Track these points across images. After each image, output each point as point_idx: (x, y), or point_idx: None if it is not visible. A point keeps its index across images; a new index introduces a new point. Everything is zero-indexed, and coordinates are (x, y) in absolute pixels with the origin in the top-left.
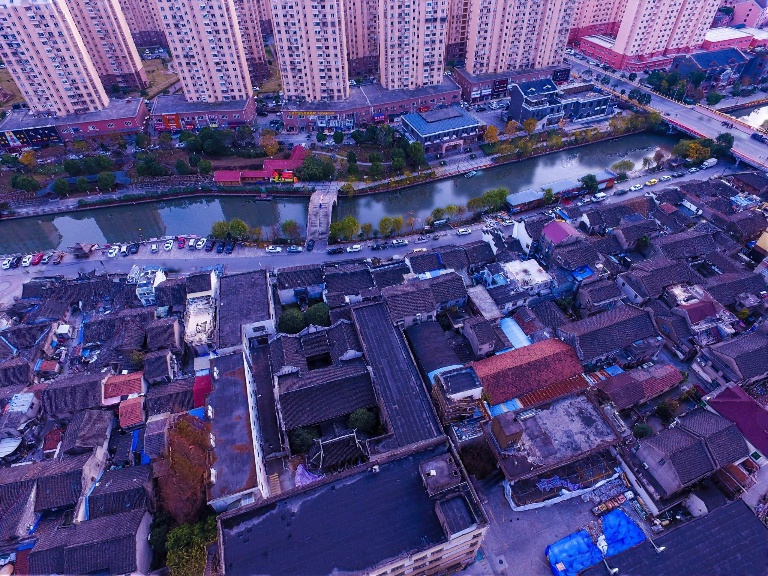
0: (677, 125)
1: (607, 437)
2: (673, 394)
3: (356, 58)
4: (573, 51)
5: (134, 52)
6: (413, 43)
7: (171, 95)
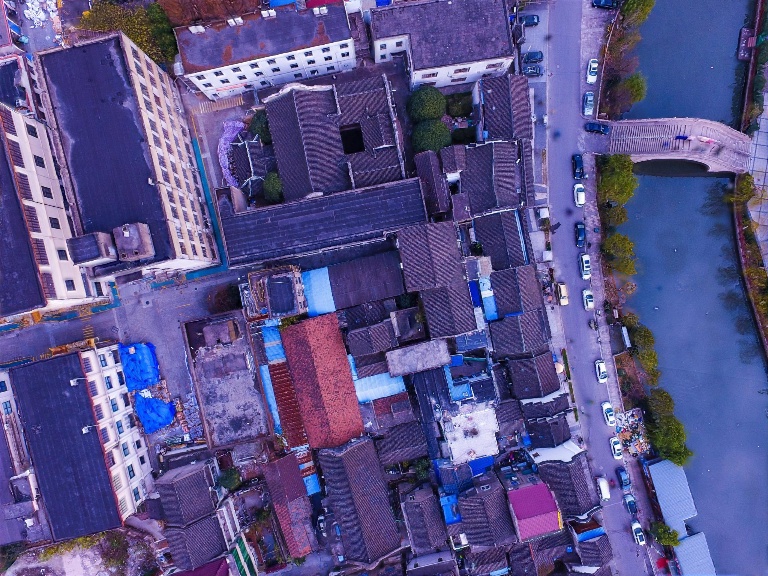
0: None
1: (217, 436)
2: None
3: None
4: None
5: None
6: None
7: None
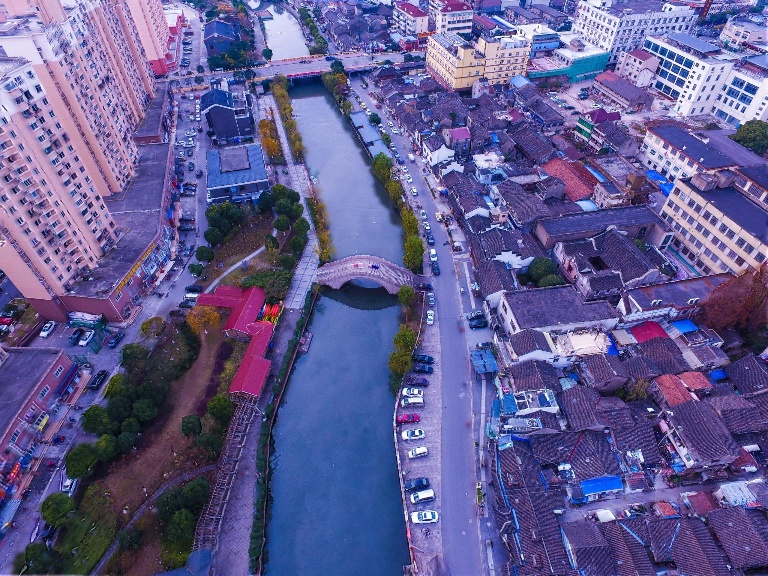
0: (296, 76)
1: None
2: None
3: None
4: None
5: None
6: (108, 120)
7: None
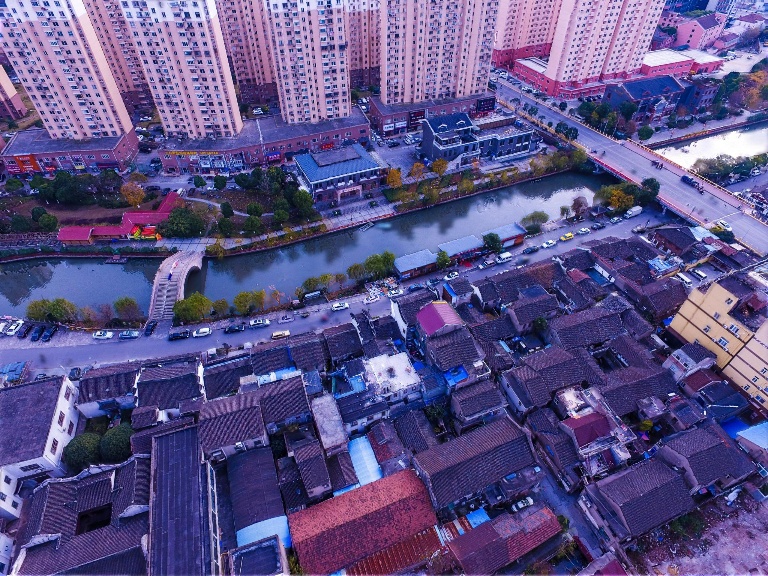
0: (603, 165)
1: None
2: (551, 546)
3: (264, 84)
4: (507, 74)
5: (2, 78)
6: (309, 73)
7: (35, 130)
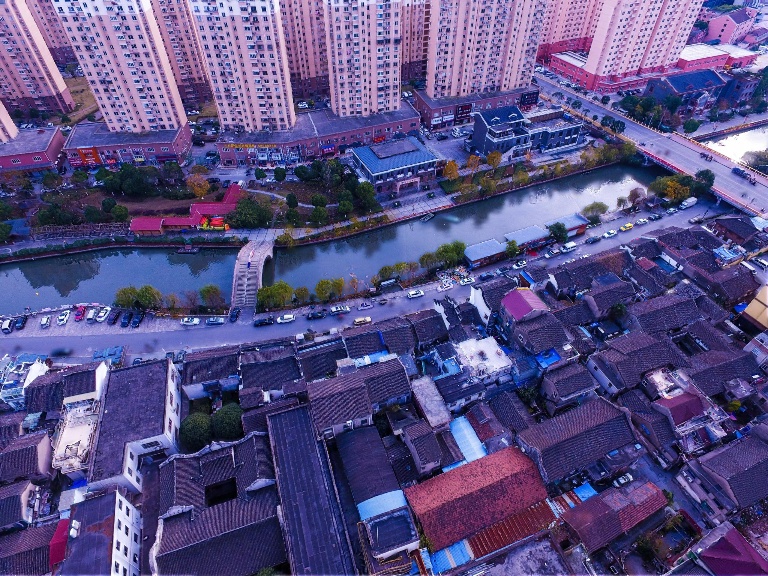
0: (653, 157)
1: None
2: (655, 519)
3: (308, 78)
4: (543, 69)
5: (54, 72)
6: (364, 67)
7: (92, 123)
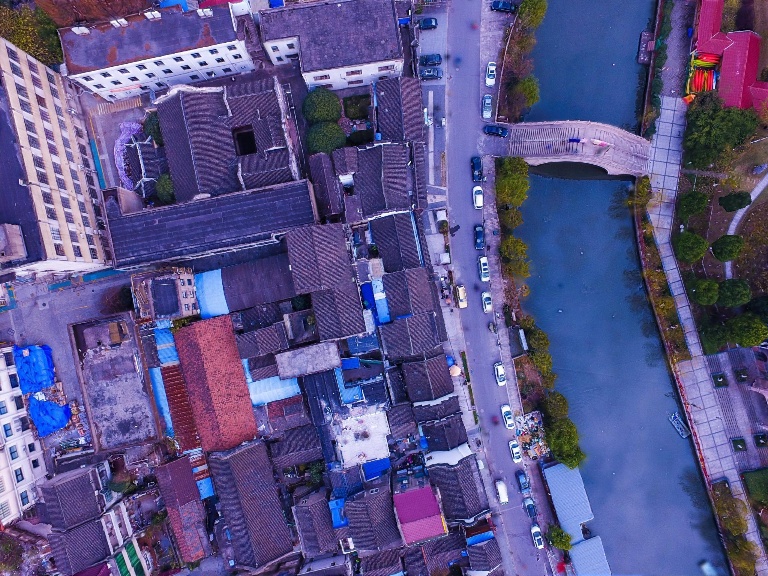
0: None
1: (104, 439)
2: None
3: None
4: None
5: None
6: None
7: None
